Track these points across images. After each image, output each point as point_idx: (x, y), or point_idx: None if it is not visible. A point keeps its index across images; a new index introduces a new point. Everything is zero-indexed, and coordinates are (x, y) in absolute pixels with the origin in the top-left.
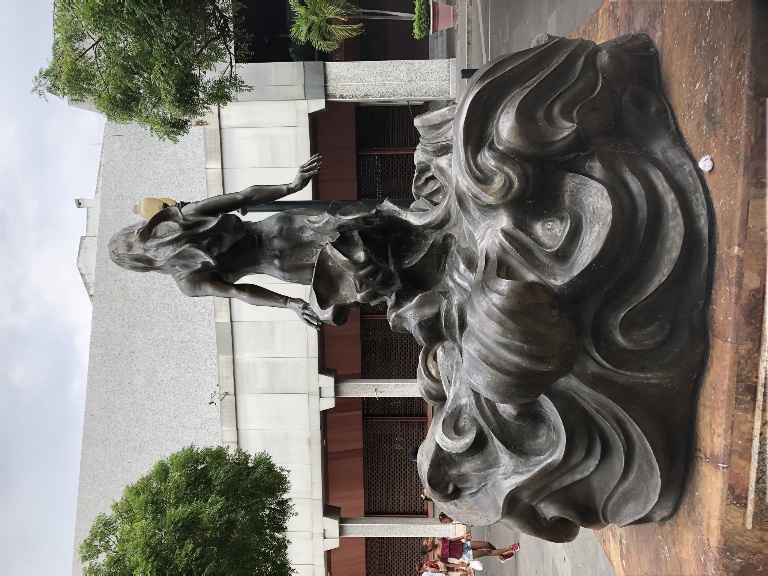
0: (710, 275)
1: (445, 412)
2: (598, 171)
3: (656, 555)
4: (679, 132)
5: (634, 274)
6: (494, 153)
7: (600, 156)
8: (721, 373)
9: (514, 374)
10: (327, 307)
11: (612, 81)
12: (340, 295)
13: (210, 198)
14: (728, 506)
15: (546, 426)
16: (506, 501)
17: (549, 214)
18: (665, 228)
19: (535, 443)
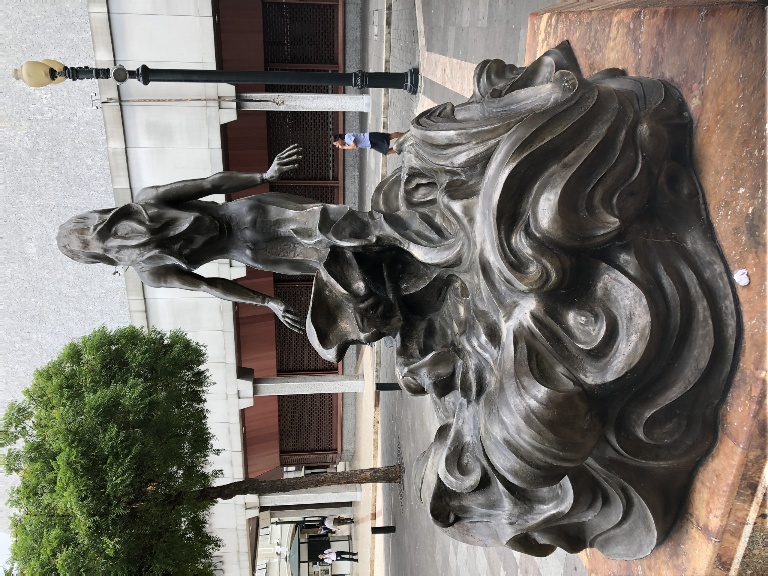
0: (729, 381)
1: (447, 448)
2: (634, 268)
3: (627, 566)
4: (710, 222)
5: (660, 375)
6: (532, 242)
7: (636, 250)
8: (727, 469)
9: (543, 468)
10: (328, 345)
11: (651, 161)
12: (339, 328)
13: (172, 184)
14: (714, 569)
15: None
16: (509, 540)
17: (580, 303)
18: (694, 334)
19: (537, 489)
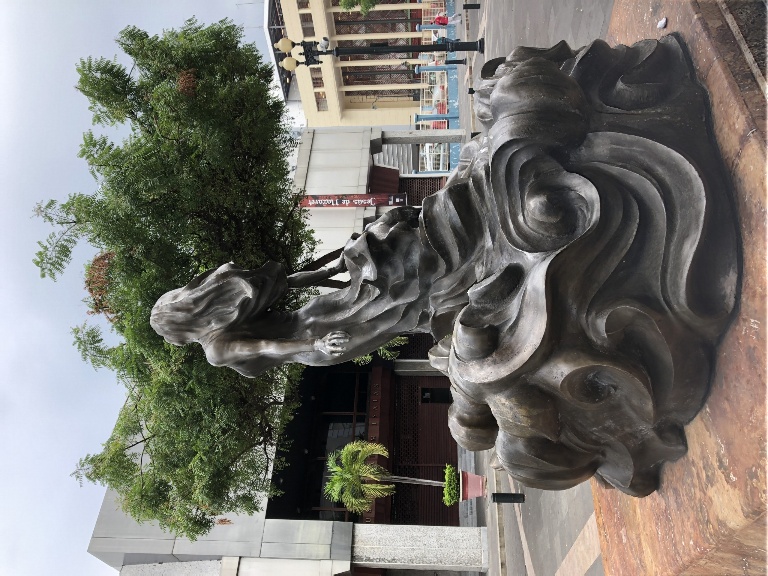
0: (687, 57)
1: None
2: None
3: (749, 358)
4: None
5: (626, 70)
6: None
7: None
8: (719, 83)
9: None
10: None
11: None
12: None
13: None
14: None
15: (581, 228)
16: (548, 282)
17: None
18: None
19: None
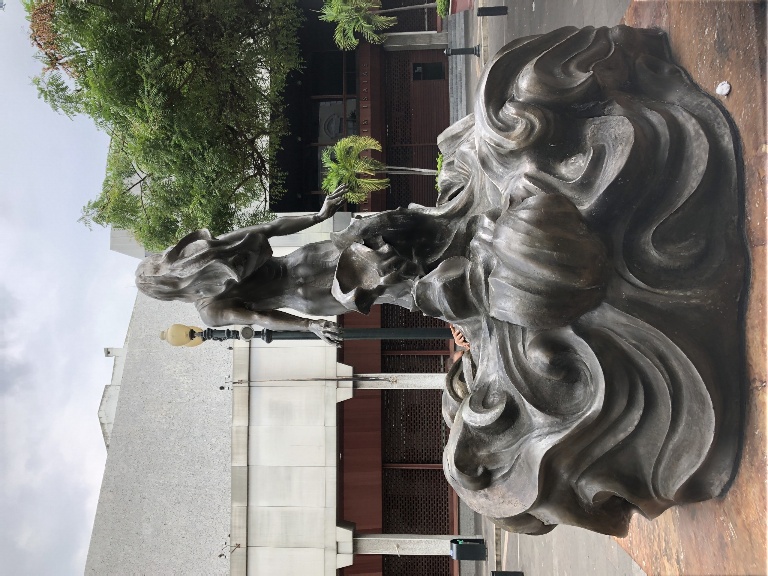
0: (741, 188)
1: (472, 391)
2: (617, 111)
3: (720, 543)
4: (694, 83)
5: (662, 194)
6: (515, 103)
7: (618, 100)
8: (766, 279)
9: (544, 292)
10: None
11: (624, 47)
12: (363, 285)
13: None
14: None
15: (582, 383)
16: (542, 468)
17: None
18: (689, 150)
19: (571, 405)
